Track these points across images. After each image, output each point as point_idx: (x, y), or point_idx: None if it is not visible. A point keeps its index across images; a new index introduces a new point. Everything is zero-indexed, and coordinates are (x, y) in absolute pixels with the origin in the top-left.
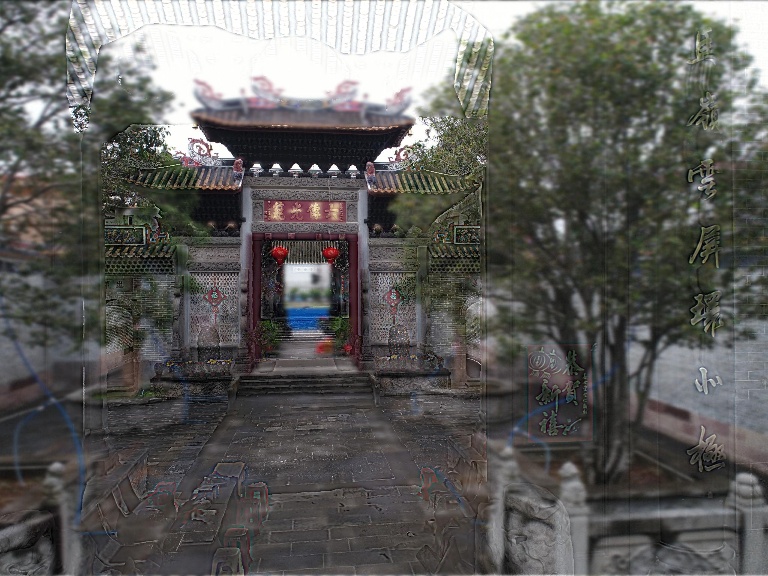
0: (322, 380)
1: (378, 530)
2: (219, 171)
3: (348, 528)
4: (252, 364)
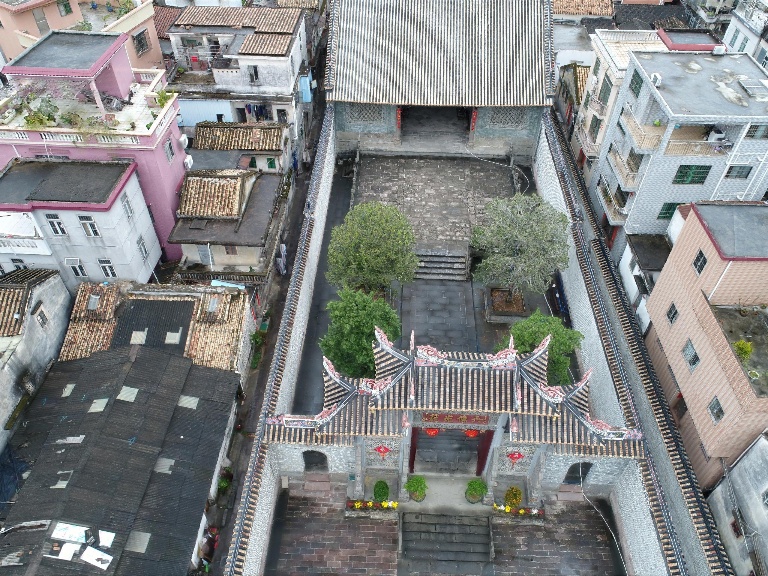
0: (456, 523)
1: None
2: None
3: None
4: (410, 498)
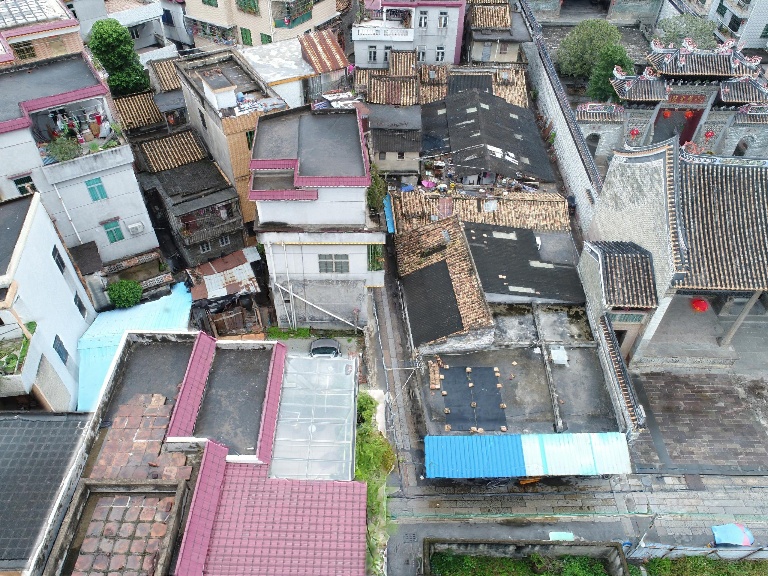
0: None
1: None
2: (656, 84)
3: None
4: None
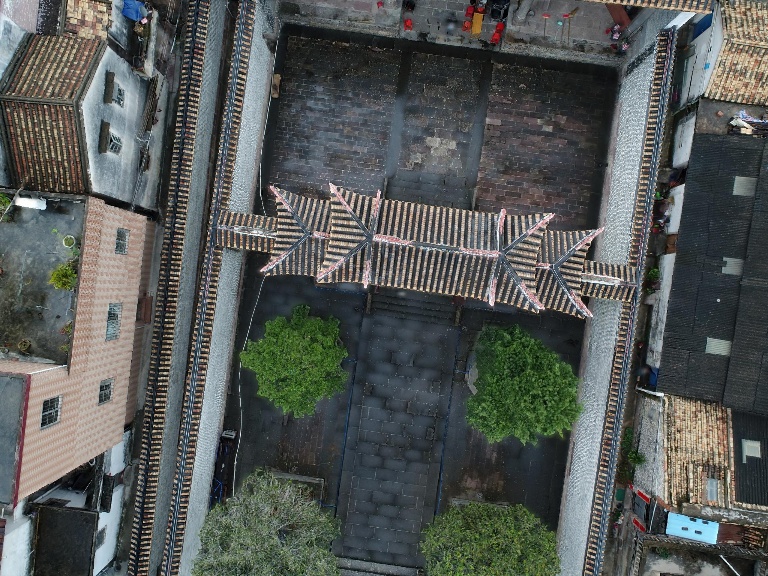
0: None
1: (433, 3)
2: None
3: (441, 7)
4: None
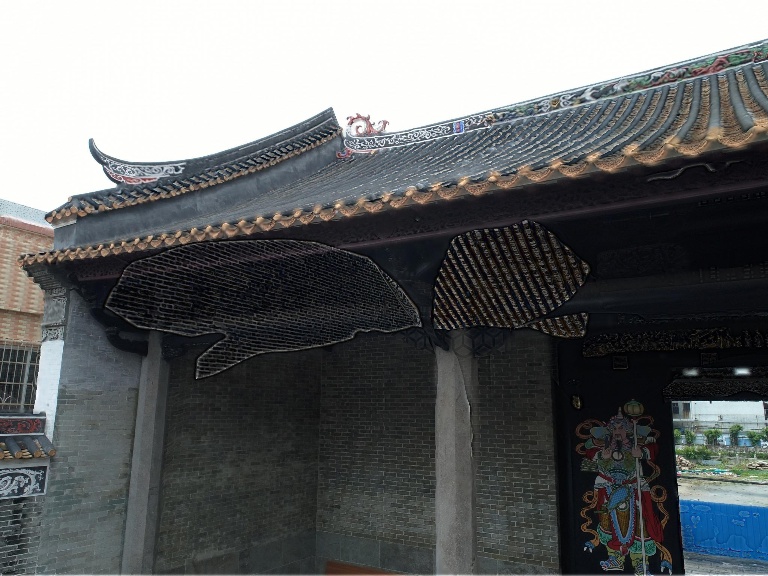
0: None
1: None
2: None
3: None
4: None
